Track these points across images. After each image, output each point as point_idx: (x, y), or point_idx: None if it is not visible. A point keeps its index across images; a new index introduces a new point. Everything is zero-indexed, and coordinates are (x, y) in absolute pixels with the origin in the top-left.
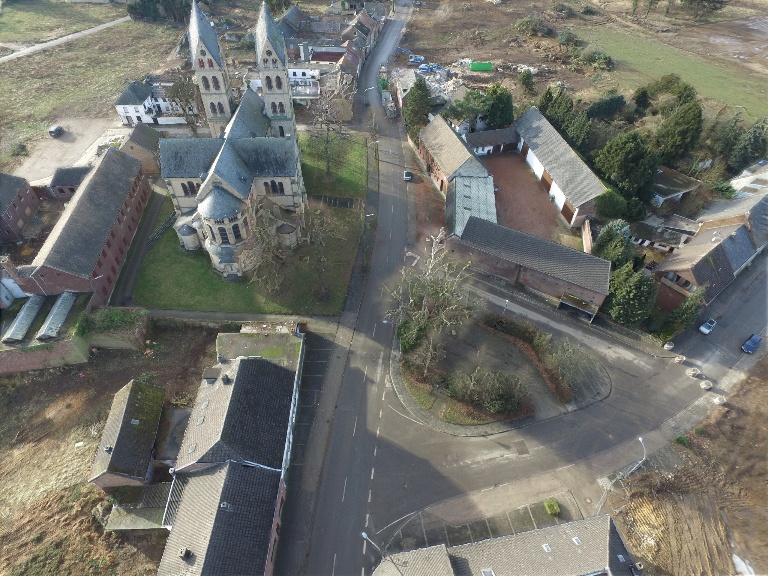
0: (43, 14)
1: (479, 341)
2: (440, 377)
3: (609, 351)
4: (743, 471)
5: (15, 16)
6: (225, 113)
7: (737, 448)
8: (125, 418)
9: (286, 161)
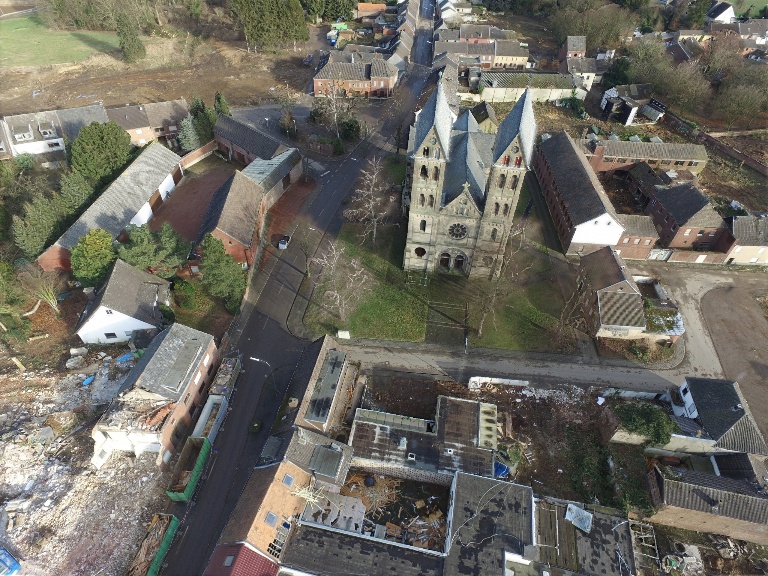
0: None
1: None
2: None
3: None
4: (242, 98)
5: None
6: None
7: (235, 101)
8: None
9: None
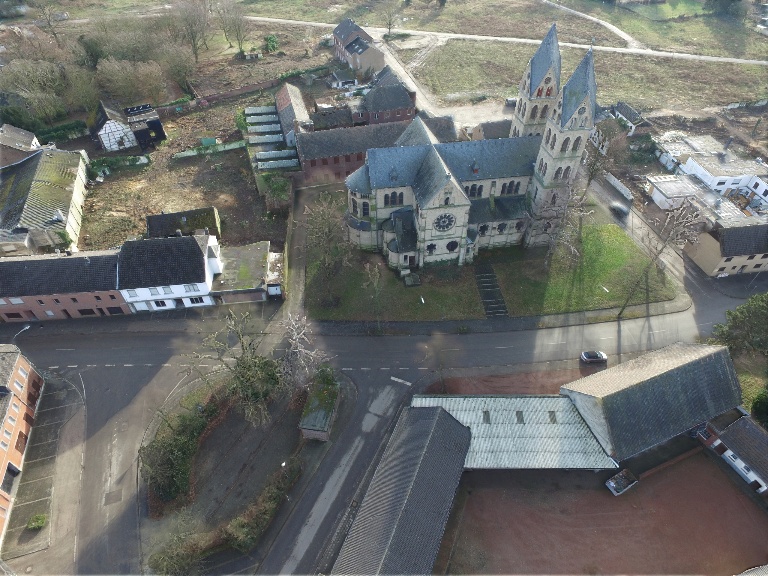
0: (712, 32)
1: (264, 456)
2: (211, 409)
3: None
4: None
5: (691, 26)
6: None
7: None
8: (184, 212)
9: (430, 193)
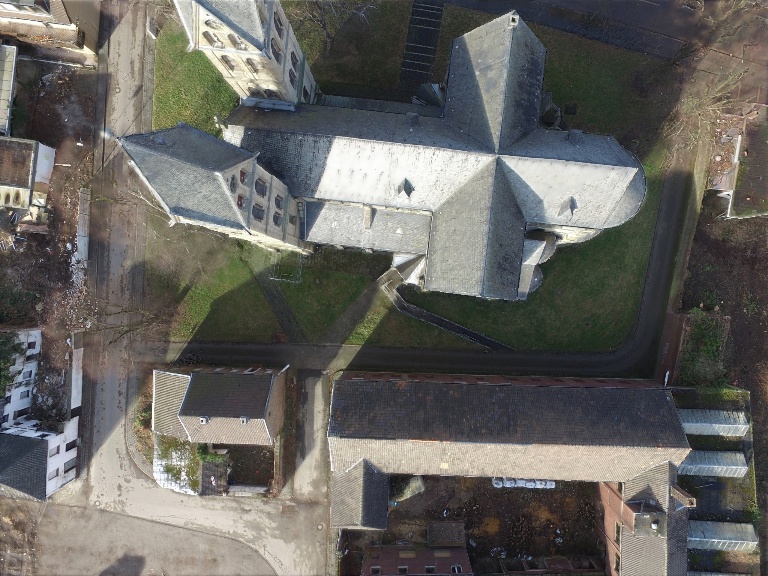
0: None
1: None
2: None
3: None
4: None
5: None
6: (282, 197)
7: None
8: None
9: (533, 53)
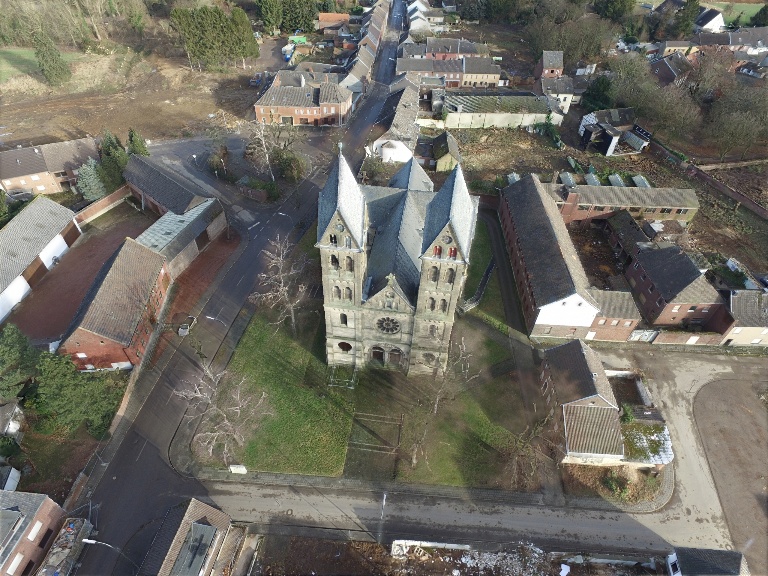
0: None
1: None
2: None
3: (175, 163)
4: (174, 128)
5: None
6: None
7: (166, 132)
8: None
9: None
